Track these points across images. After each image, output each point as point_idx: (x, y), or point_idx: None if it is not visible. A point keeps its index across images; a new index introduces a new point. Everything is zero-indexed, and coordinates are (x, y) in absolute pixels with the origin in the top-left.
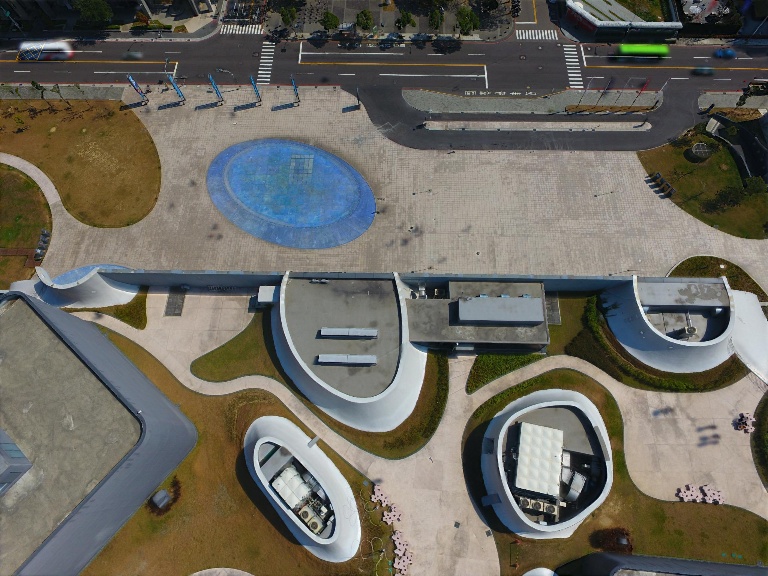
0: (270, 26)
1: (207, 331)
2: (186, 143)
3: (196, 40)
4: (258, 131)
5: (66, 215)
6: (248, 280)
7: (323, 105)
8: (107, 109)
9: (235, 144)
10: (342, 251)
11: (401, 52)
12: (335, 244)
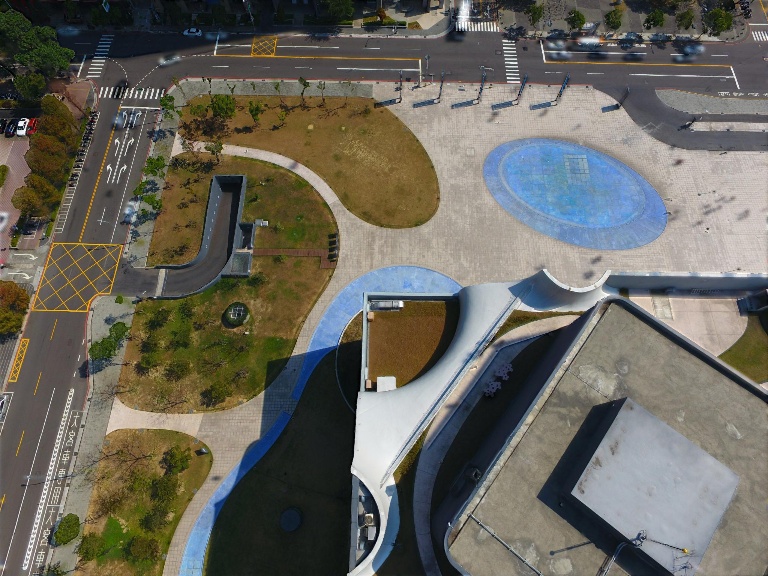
0: (505, 24)
1: (706, 335)
2: (453, 142)
3: (433, 37)
4: (523, 130)
5: (349, 215)
6: (750, 283)
7: (581, 104)
8: (366, 106)
9: (503, 143)
10: (645, 252)
11: (644, 52)
12: (635, 245)
